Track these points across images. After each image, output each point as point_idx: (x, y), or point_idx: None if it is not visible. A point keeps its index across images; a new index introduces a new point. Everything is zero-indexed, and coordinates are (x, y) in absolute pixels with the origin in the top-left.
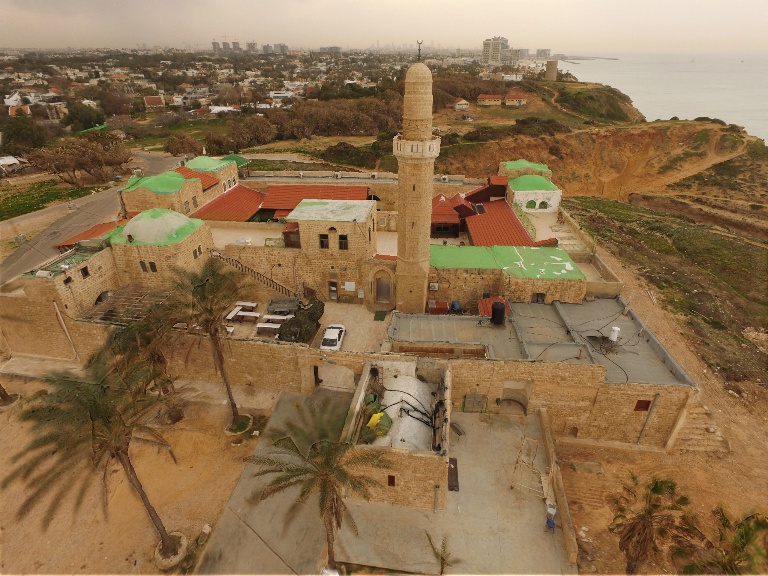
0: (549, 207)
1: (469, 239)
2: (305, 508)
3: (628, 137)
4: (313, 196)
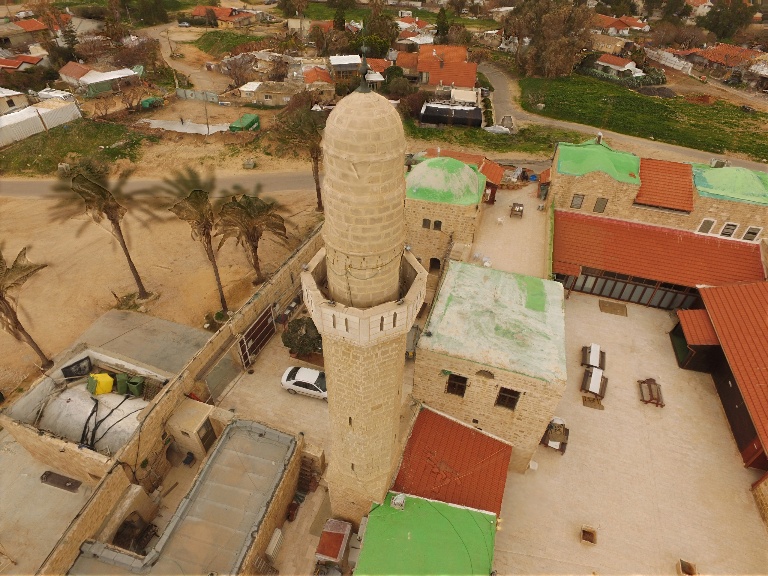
0: None
1: None
2: None
3: None
4: None
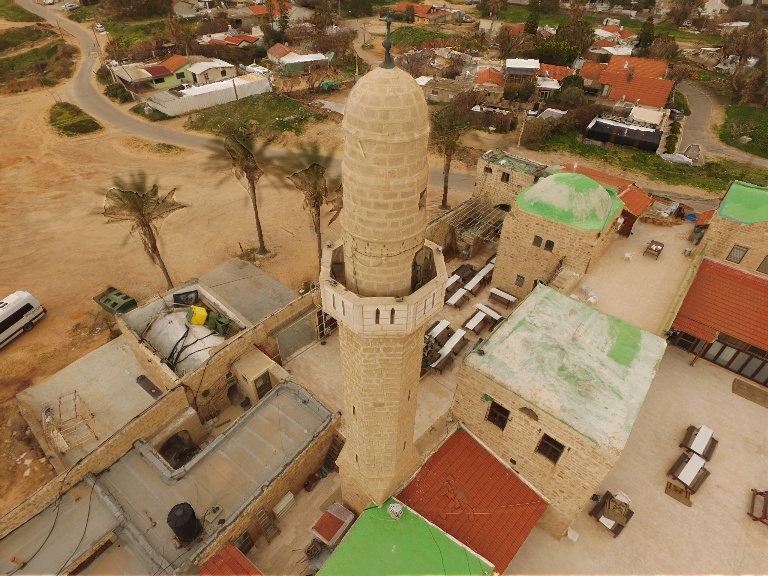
0: None
1: None
2: None
3: None
4: None
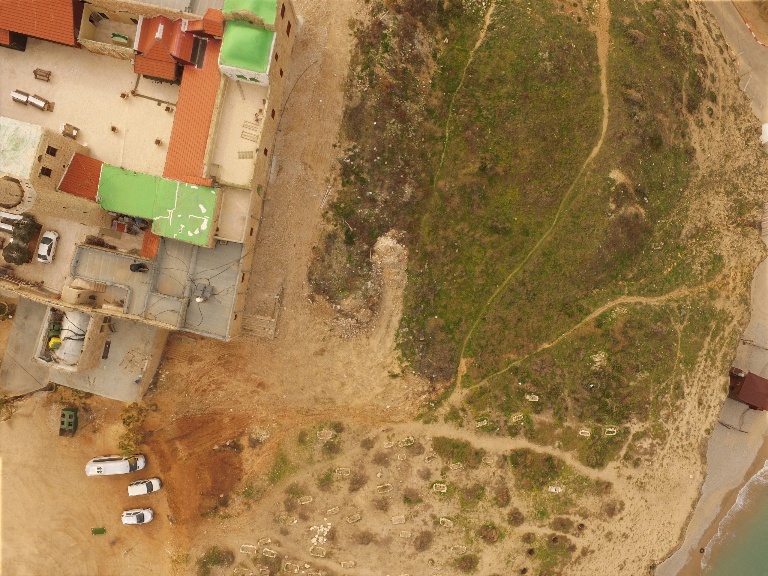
0: (261, 82)
1: None
2: None
3: None
4: (13, 5)
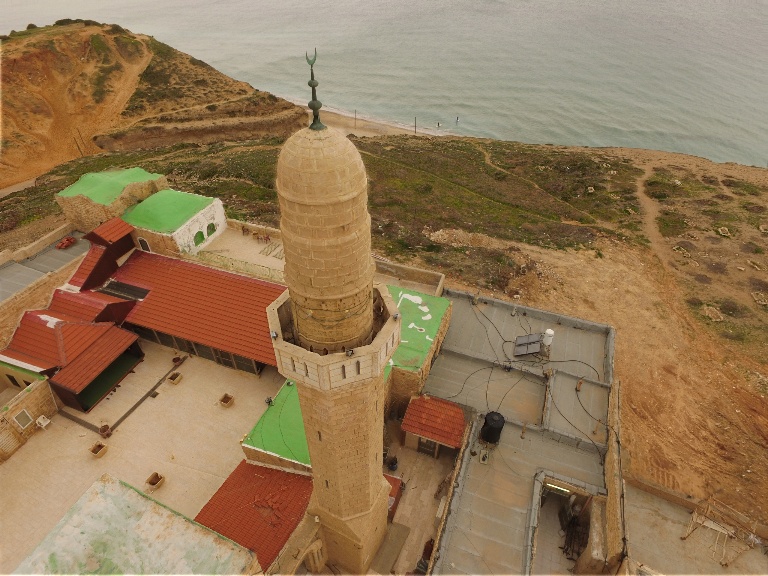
0: (217, 227)
1: (187, 348)
2: None
3: (12, 65)
4: None
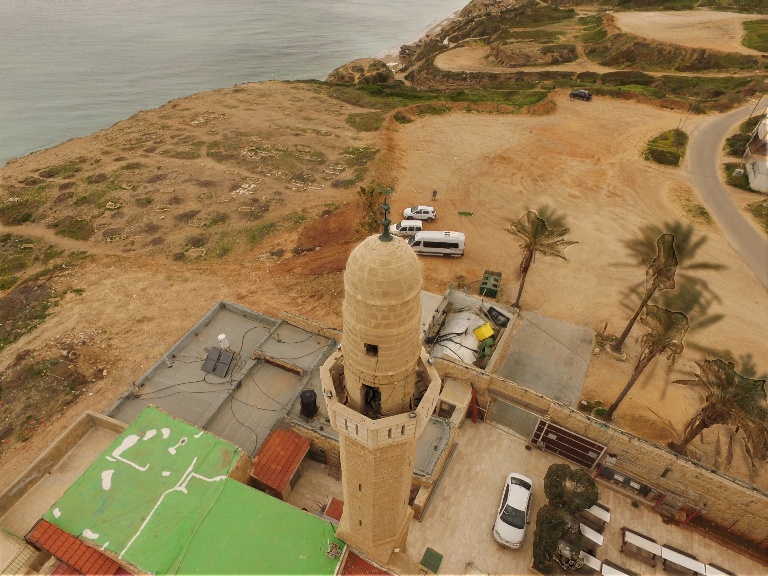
0: None
1: None
2: (533, 346)
3: None
4: None
